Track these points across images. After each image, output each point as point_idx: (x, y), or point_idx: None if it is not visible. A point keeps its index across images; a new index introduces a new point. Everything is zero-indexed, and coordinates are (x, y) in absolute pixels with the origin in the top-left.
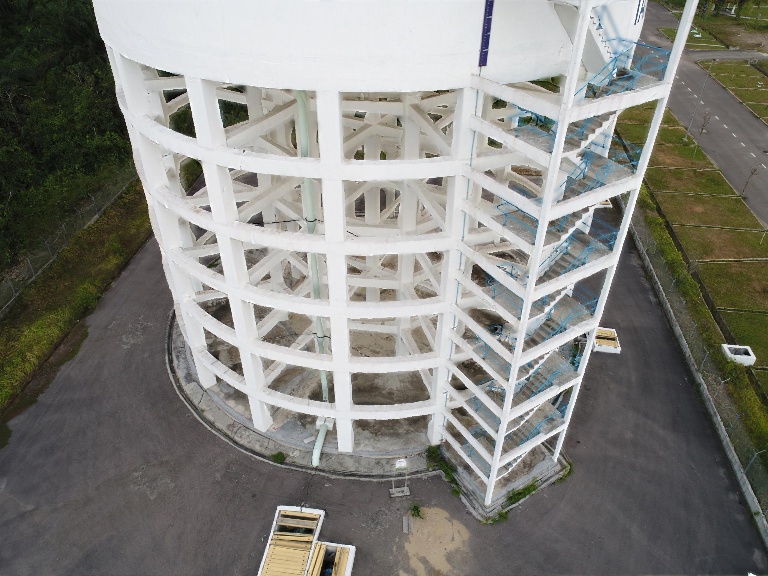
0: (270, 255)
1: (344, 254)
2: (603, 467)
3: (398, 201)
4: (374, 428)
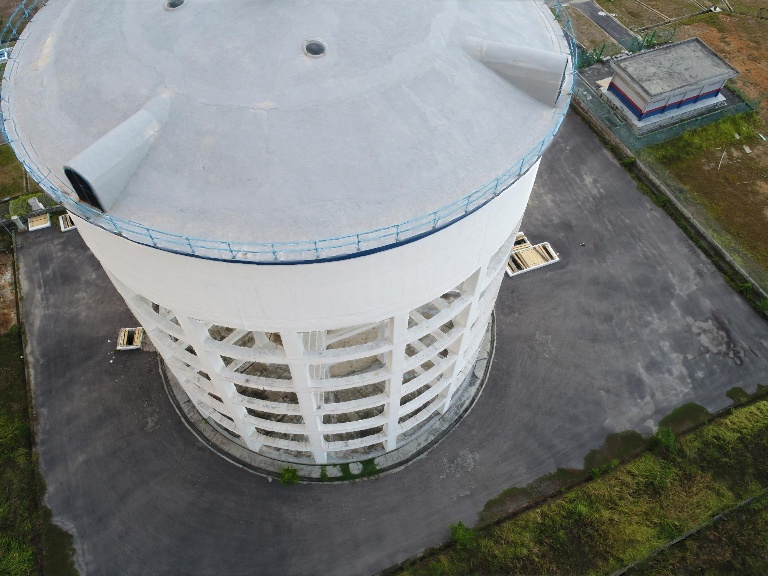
0: None
1: None
2: None
3: None
4: None
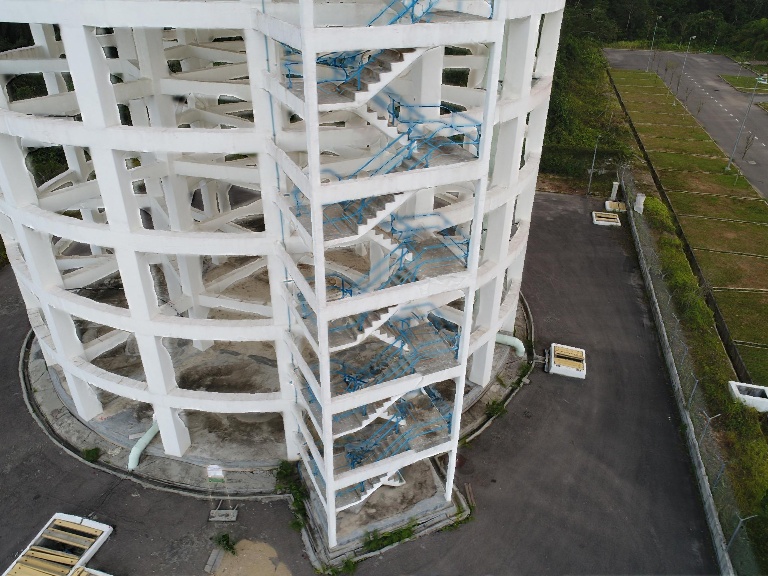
0: (88, 182)
1: (110, 148)
2: (519, 518)
3: None
4: (225, 431)
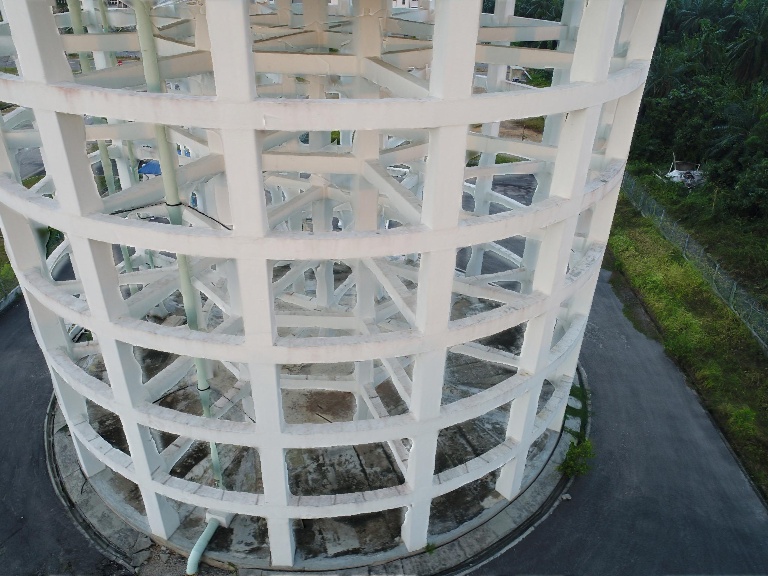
0: None
1: None
2: None
3: (285, 276)
4: None
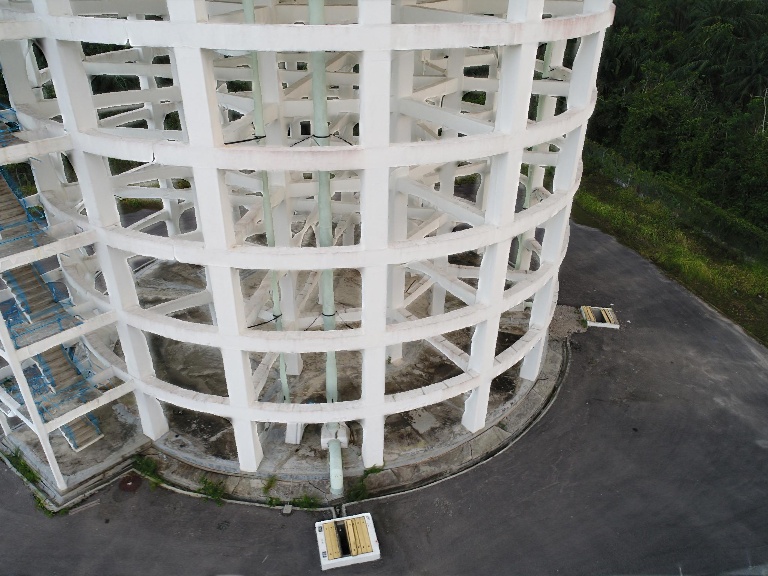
0: None
1: None
2: (57, 554)
3: None
4: None
